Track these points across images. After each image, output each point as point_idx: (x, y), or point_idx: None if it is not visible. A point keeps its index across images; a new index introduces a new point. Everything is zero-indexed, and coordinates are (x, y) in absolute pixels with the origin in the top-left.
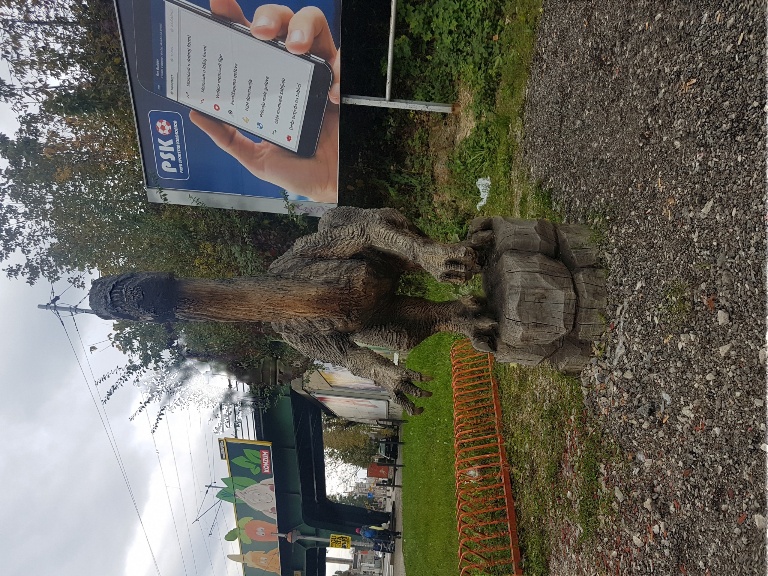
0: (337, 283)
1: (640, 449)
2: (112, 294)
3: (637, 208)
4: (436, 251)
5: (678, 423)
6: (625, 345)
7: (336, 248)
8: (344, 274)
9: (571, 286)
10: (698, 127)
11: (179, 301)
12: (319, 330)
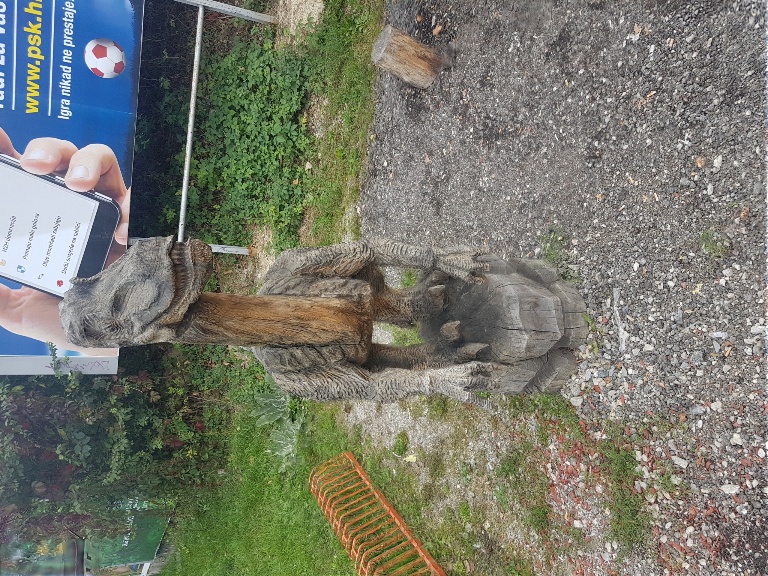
0: (351, 300)
1: (694, 403)
2: (172, 255)
3: (601, 214)
4: (461, 250)
5: (746, 347)
6: (626, 330)
7: (339, 267)
8: (354, 292)
9: (554, 294)
10: (678, 116)
11: (202, 304)
12: (328, 362)
